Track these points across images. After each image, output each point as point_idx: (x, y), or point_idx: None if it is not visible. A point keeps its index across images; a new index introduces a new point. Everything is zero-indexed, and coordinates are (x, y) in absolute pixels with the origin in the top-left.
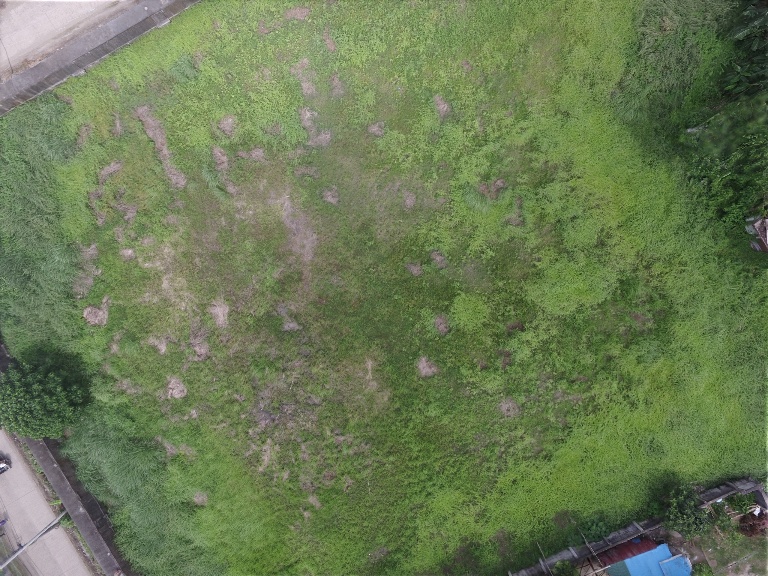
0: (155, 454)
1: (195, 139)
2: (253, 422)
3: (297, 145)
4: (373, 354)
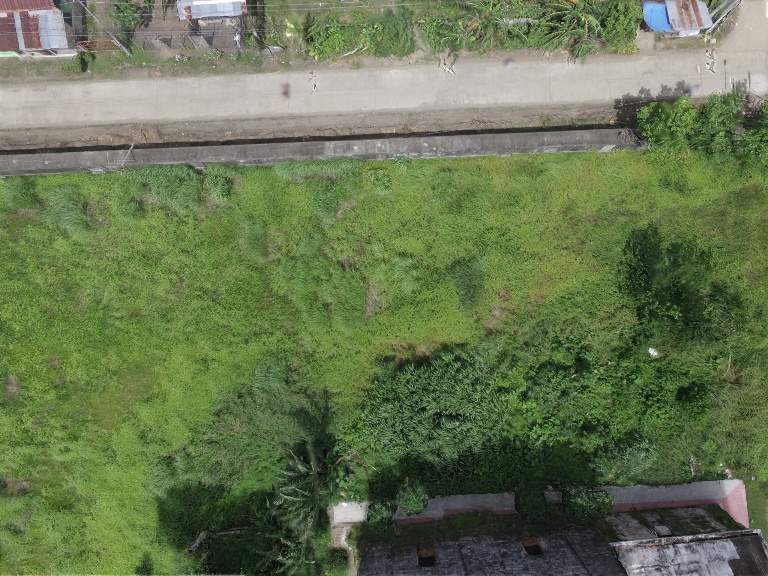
0: None
1: None
2: None
3: None
4: None
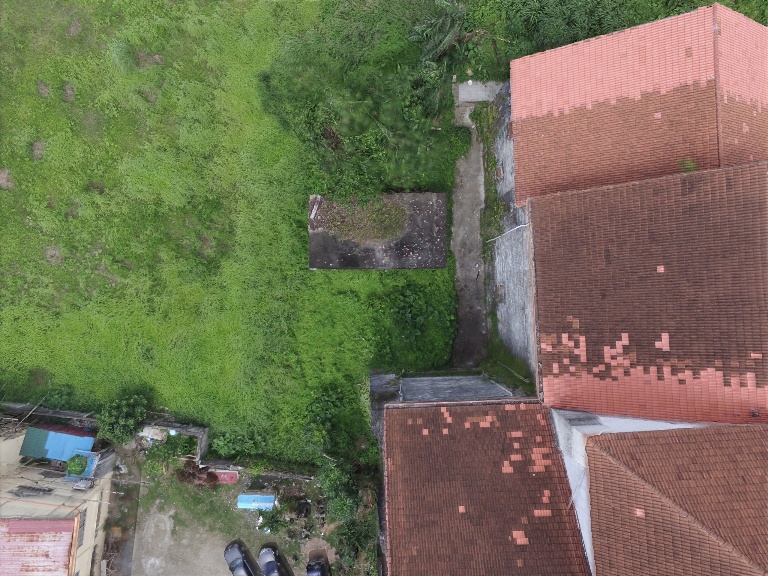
0: None
1: None
2: None
3: None
4: None
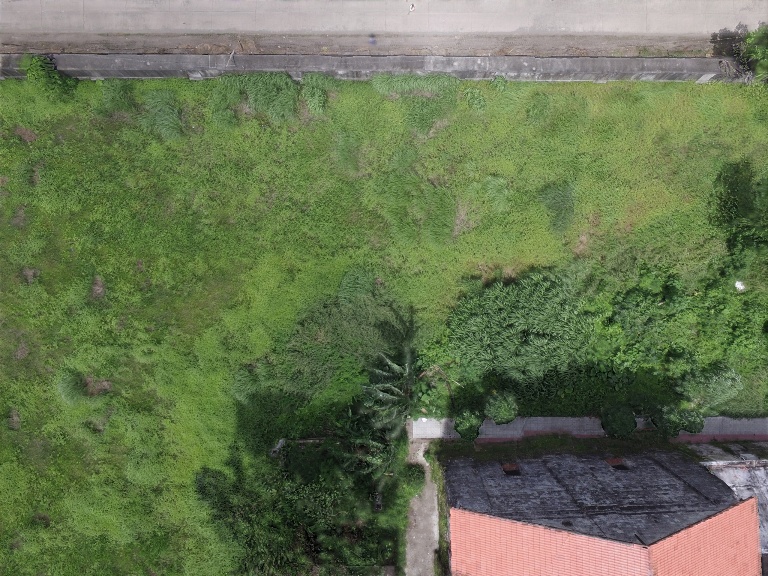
0: None
1: None
2: None
3: None
4: None
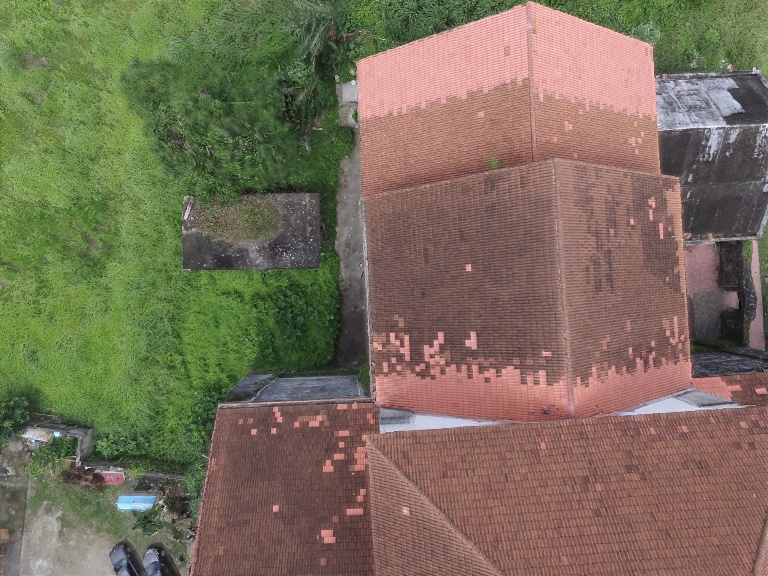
0: None
1: None
2: None
3: None
4: None
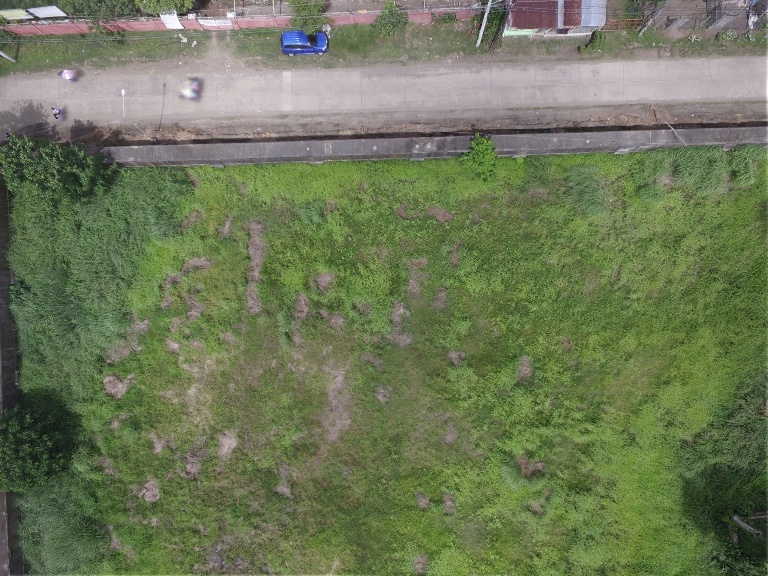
0: (99, 544)
1: (289, 279)
2: (203, 559)
3: (377, 333)
4: (344, 557)
